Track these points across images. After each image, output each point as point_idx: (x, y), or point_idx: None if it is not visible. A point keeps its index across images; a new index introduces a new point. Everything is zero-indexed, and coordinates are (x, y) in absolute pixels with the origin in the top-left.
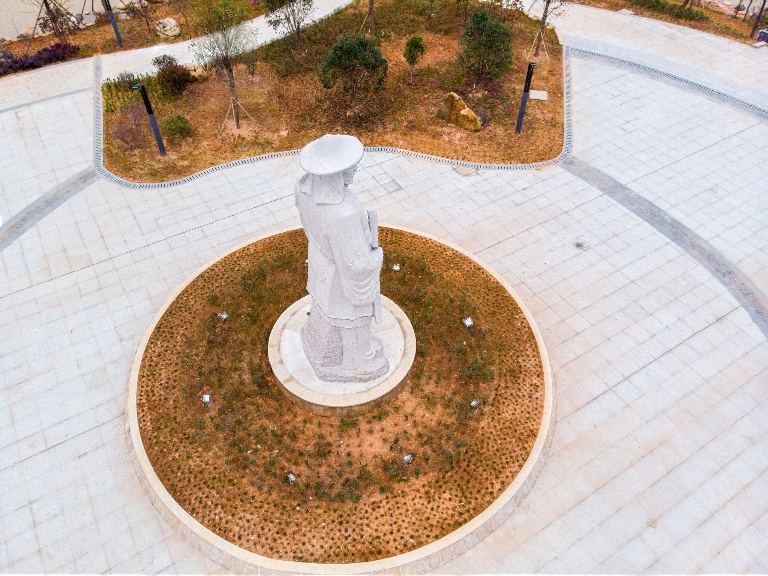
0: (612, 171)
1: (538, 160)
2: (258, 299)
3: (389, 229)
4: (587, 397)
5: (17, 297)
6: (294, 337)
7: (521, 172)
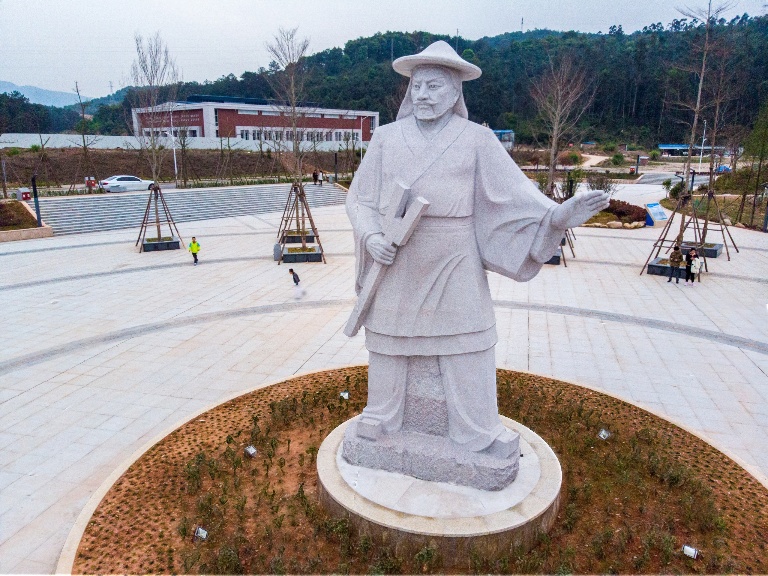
0: None
1: None
2: None
3: None
4: None
5: (760, 378)
6: None
7: None
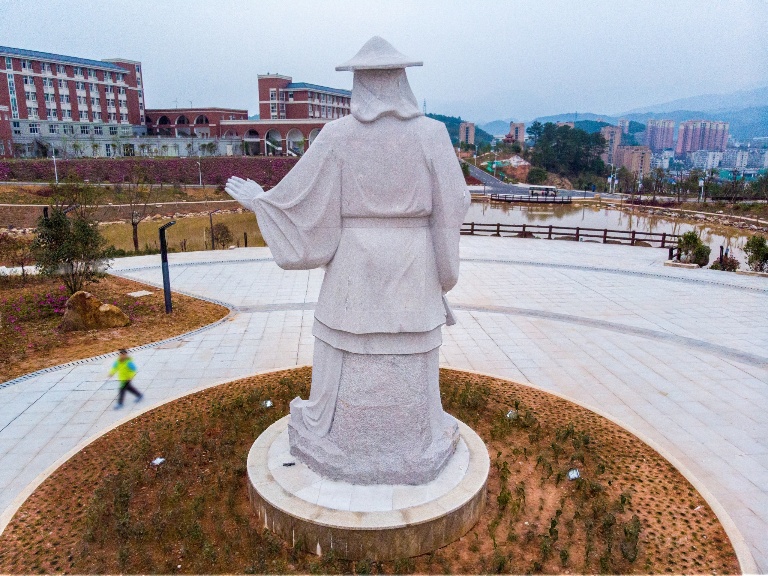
0: (283, 301)
1: (220, 317)
2: (164, 535)
3: (194, 394)
4: (522, 379)
5: None
6: (320, 488)
7: (222, 326)
